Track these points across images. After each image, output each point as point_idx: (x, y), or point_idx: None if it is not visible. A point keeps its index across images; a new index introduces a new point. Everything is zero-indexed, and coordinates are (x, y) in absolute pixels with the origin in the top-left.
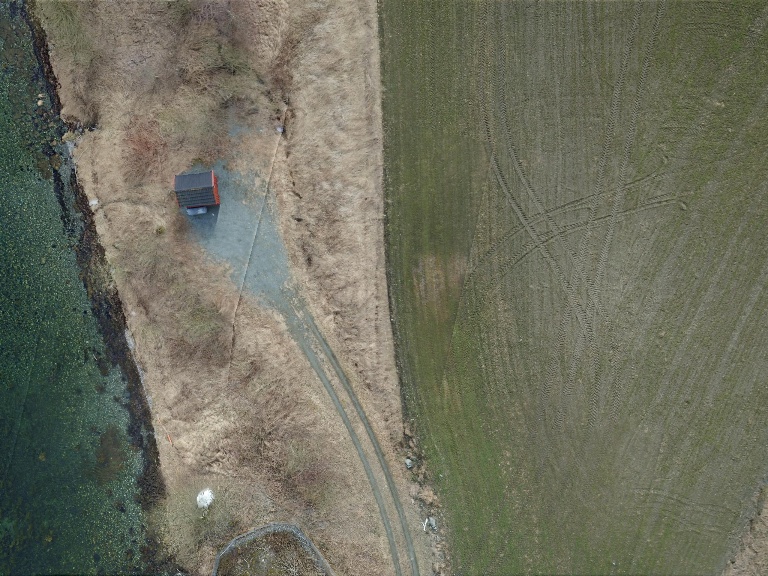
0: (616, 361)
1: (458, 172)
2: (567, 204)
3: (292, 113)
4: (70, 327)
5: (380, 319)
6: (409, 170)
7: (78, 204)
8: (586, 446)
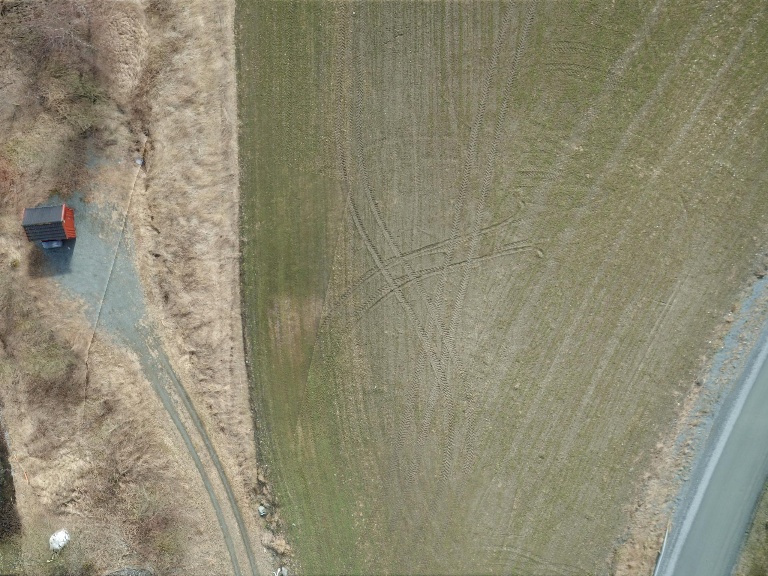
0: (470, 412)
1: (314, 211)
2: (423, 248)
3: (151, 145)
4: None
5: (234, 361)
6: (265, 208)
7: None
8: (439, 499)
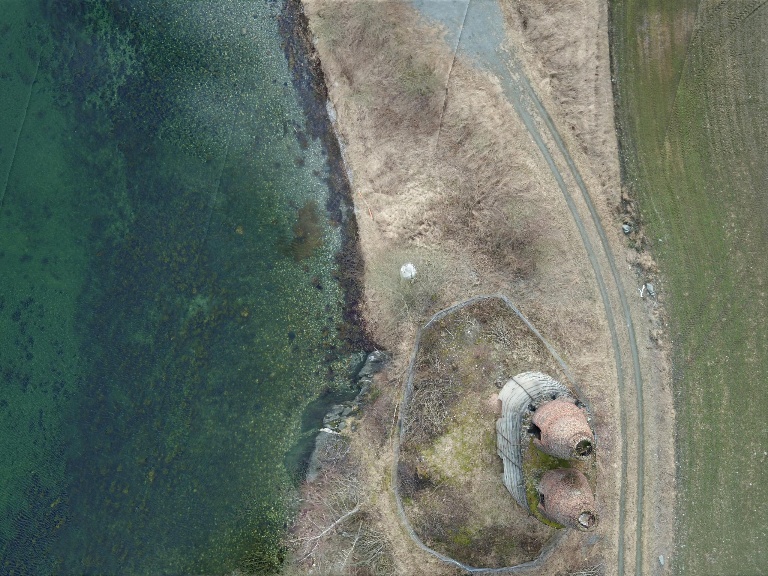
0: None
1: None
2: None
3: None
4: (269, 99)
5: (600, 79)
6: None
7: None
8: None
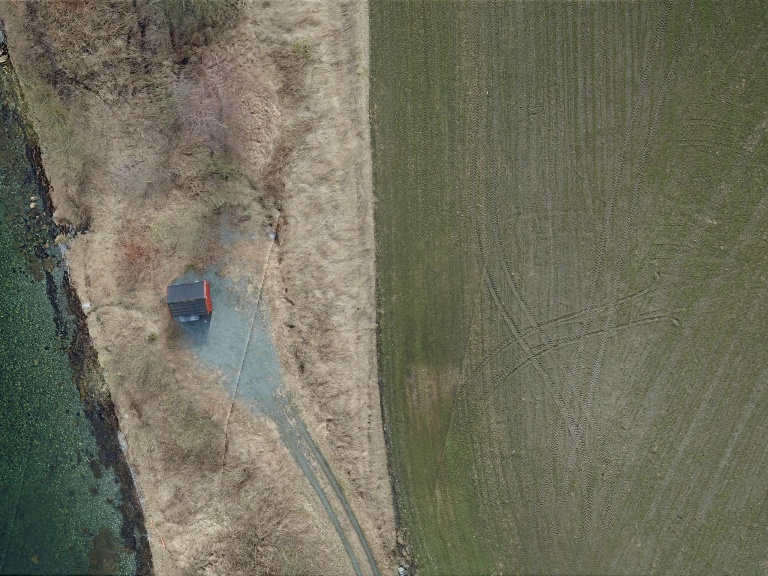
0: (609, 475)
1: (450, 284)
2: (559, 318)
3: (284, 220)
4: (63, 429)
5: (373, 428)
6: (401, 281)
7: (71, 307)
8: (579, 559)
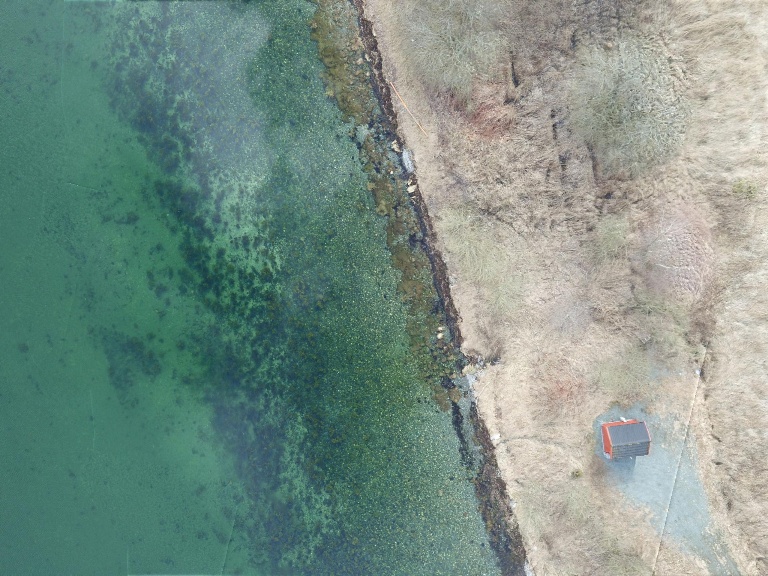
0: None
1: None
2: None
3: (712, 357)
4: (467, 559)
5: None
6: None
7: (478, 437)
8: None
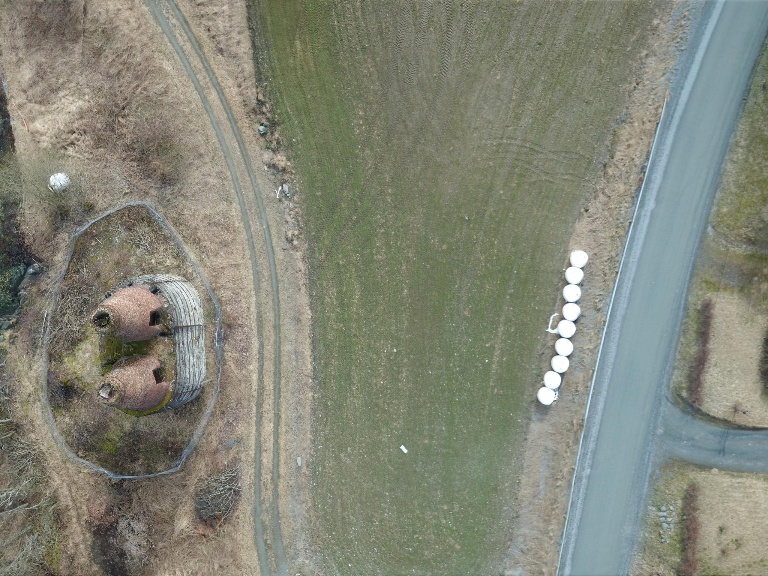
0: (468, 6)
1: None
2: None
3: None
4: None
5: None
6: None
7: None
8: (438, 98)
